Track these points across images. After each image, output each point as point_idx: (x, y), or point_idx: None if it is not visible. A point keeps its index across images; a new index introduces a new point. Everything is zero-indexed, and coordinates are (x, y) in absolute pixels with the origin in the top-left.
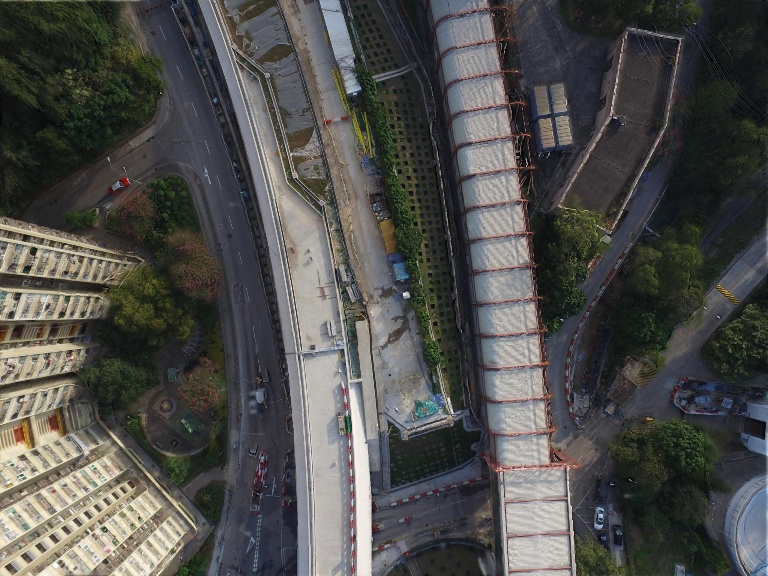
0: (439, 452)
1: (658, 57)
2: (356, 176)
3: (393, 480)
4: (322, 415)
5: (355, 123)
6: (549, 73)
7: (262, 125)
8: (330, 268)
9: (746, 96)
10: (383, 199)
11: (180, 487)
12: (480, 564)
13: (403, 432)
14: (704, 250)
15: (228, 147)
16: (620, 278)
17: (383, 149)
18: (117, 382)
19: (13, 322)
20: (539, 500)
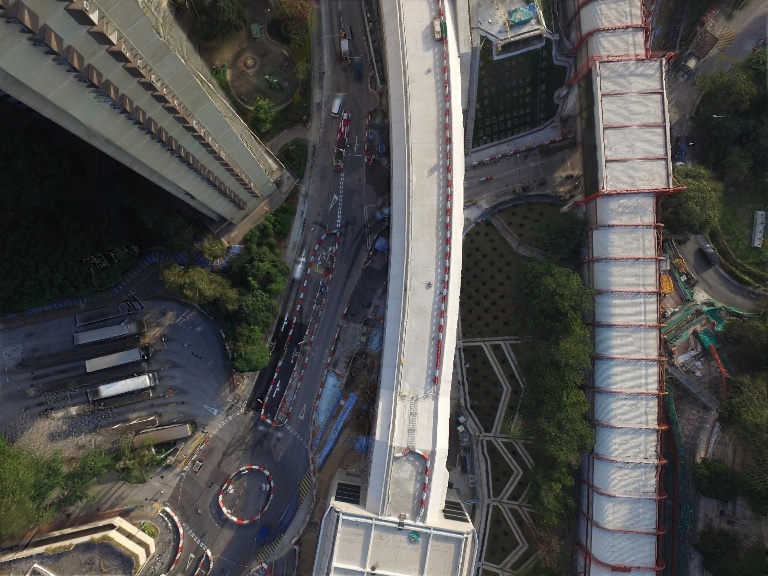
0: (524, 93)
1: None
2: None
3: (475, 135)
4: (417, 23)
5: None
6: None
7: None
8: None
9: None
10: None
11: (264, 143)
12: (563, 207)
13: (497, 41)
14: None
15: None
16: None
17: None
18: None
19: None
20: (635, 92)
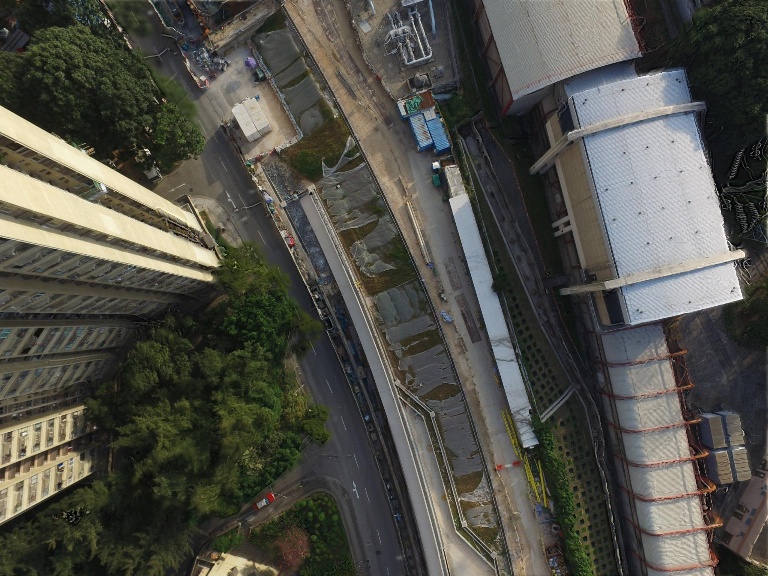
0: None
1: None
2: (529, 524)
3: None
4: None
5: (527, 469)
6: (716, 389)
7: (427, 466)
8: None
9: None
10: (560, 554)
11: None
12: None
13: None
14: None
15: (380, 466)
16: None
17: (565, 511)
18: None
19: None
20: None
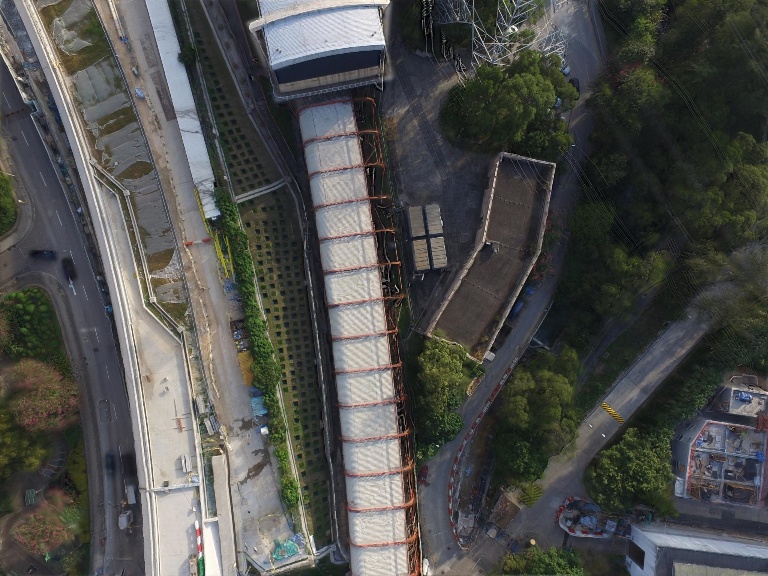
0: None
1: (534, 180)
2: (218, 301)
3: None
4: (174, 557)
5: (217, 246)
6: (429, 188)
7: (120, 244)
8: (187, 398)
9: (622, 222)
10: (244, 327)
11: None
12: None
13: (261, 574)
14: (591, 365)
15: (93, 259)
16: None
17: (241, 278)
18: None
19: None
20: None
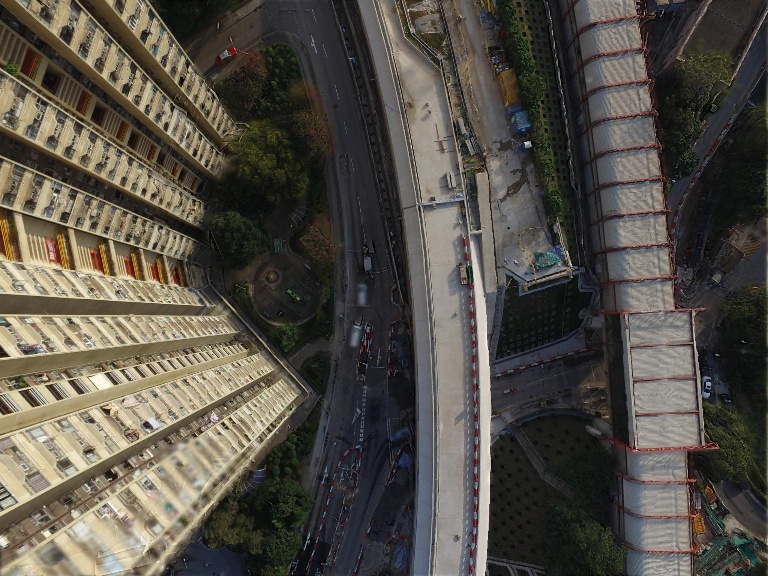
0: (549, 316)
1: None
2: (473, 31)
3: (499, 349)
4: (442, 266)
5: None
6: None
7: None
8: (448, 122)
9: None
10: (502, 51)
11: (286, 357)
12: (590, 429)
13: (523, 284)
14: None
15: (336, 14)
16: (723, 150)
17: None
18: (241, 231)
19: (165, 136)
20: (665, 345)
